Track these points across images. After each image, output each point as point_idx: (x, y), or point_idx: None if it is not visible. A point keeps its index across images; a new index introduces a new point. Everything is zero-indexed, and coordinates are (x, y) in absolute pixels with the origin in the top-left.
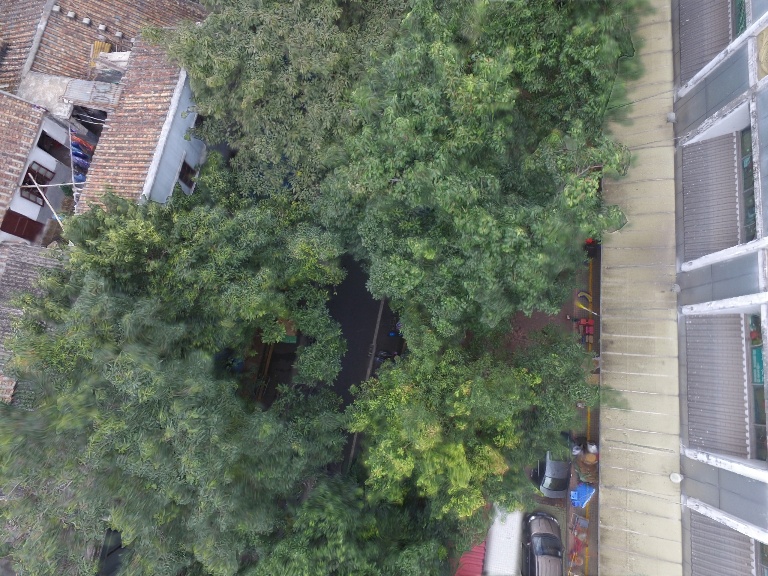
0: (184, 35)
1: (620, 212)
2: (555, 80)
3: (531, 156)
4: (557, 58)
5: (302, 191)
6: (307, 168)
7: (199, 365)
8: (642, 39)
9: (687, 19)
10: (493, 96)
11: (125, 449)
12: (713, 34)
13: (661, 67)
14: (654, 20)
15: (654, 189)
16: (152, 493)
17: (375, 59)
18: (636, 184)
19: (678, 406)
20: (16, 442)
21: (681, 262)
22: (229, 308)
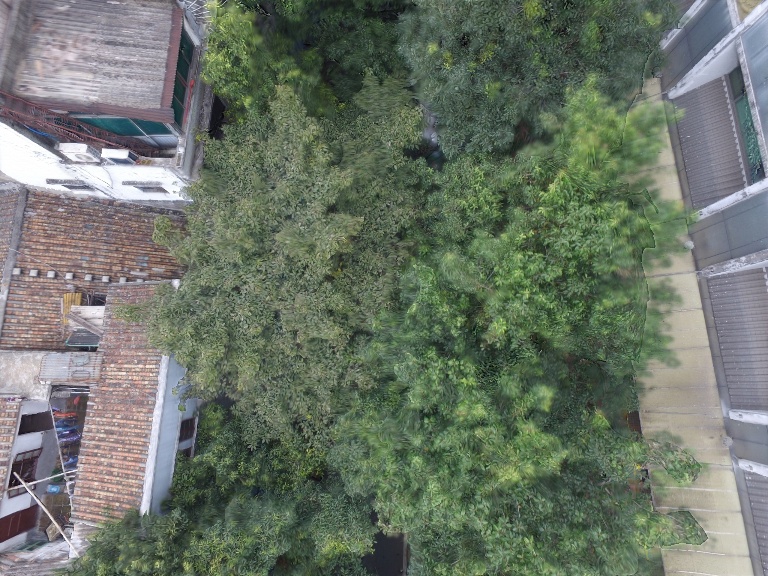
0: (163, 331)
1: (699, 531)
2: (585, 332)
3: (576, 437)
4: (587, 321)
5: (315, 435)
6: (317, 410)
7: None
8: (640, 153)
9: (687, 135)
10: (540, 457)
11: None
12: (720, 154)
13: (666, 184)
14: (650, 132)
15: (682, 321)
16: None
17: (379, 328)
18: (661, 316)
19: (751, 568)
20: None
21: (727, 407)
22: None
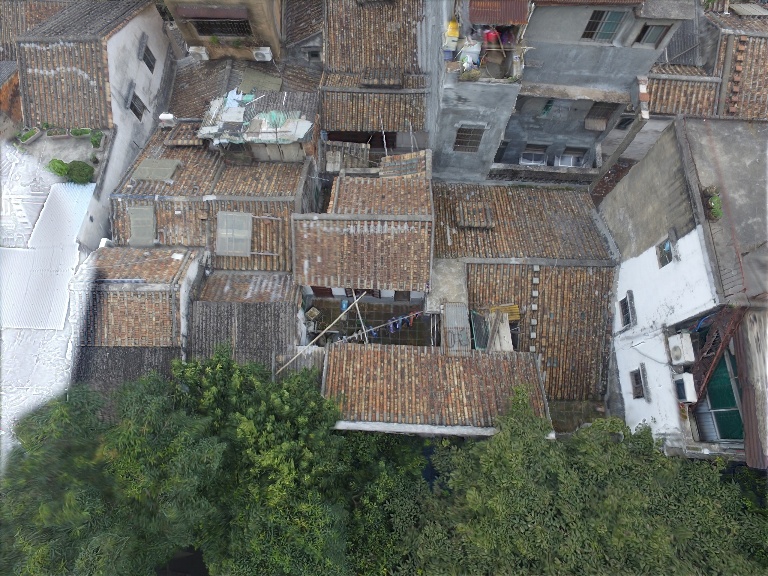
0: (516, 455)
1: None
2: None
3: None
4: None
5: None
6: None
7: (170, 547)
8: None
9: None
10: None
11: (29, 572)
12: None
13: None
14: None
15: None
16: (12, 575)
17: None
18: None
19: None
20: (29, 478)
21: None
22: (227, 572)
